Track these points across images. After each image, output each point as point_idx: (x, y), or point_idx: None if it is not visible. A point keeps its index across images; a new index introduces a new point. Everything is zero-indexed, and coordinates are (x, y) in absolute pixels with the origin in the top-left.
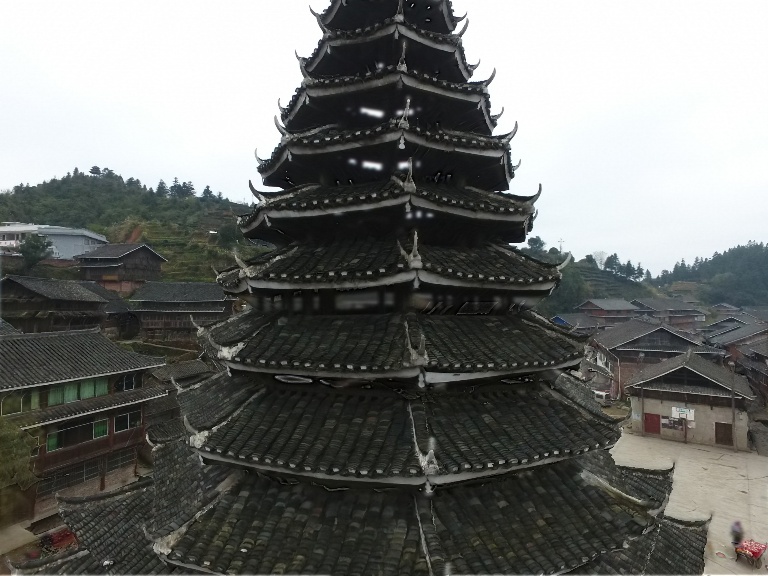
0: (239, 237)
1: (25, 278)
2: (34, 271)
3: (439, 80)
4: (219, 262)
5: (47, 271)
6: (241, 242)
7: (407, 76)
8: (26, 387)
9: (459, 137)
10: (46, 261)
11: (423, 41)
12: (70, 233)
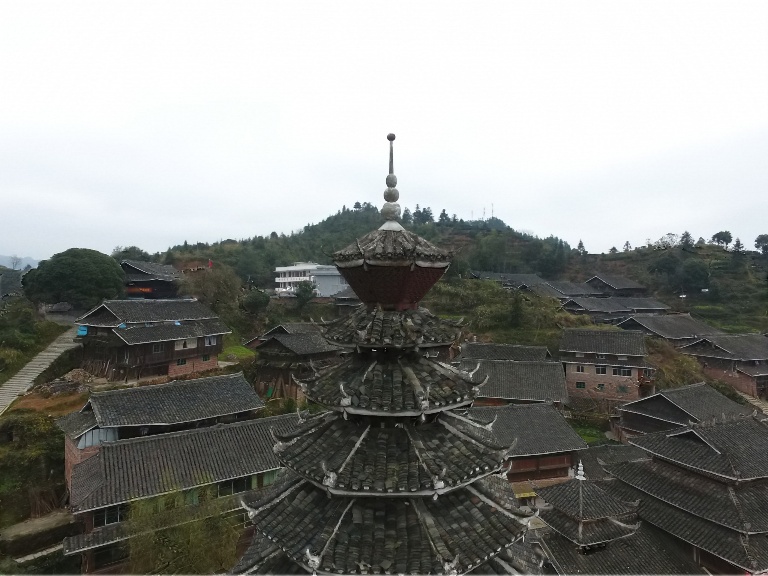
0: (462, 271)
1: (285, 335)
2: (305, 308)
3: (374, 485)
4: (442, 298)
5: (313, 308)
6: (463, 276)
7: (334, 489)
8: (246, 475)
9: (383, 568)
10: (313, 299)
11: (378, 414)
12: (330, 273)
